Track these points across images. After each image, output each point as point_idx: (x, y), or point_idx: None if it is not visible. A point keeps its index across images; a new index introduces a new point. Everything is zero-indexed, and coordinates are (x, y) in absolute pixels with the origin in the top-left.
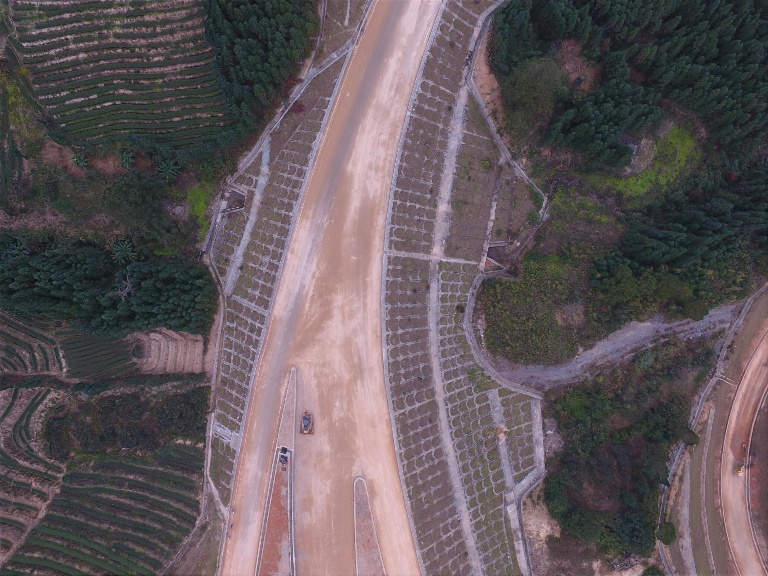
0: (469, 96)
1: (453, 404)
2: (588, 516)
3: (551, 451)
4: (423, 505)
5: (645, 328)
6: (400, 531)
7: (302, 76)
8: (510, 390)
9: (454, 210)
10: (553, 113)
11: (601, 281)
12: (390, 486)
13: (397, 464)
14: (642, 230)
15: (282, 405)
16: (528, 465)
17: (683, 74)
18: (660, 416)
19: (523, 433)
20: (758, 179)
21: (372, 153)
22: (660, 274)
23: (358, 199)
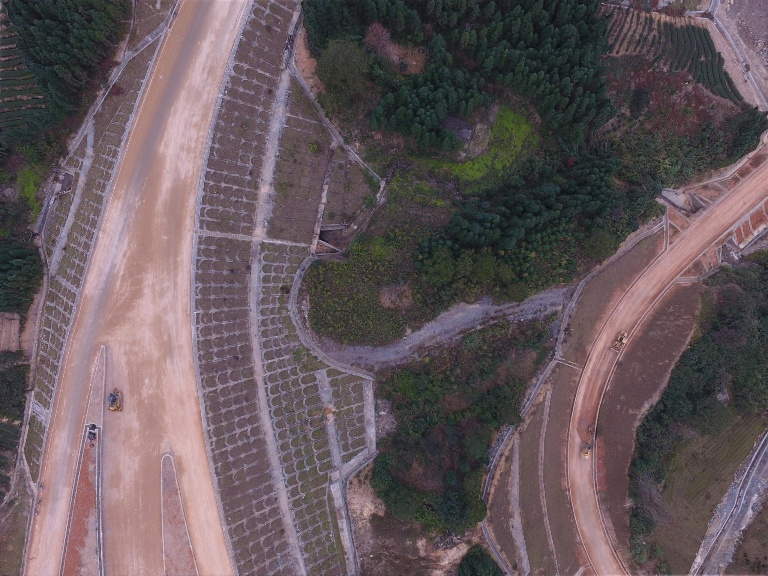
0: (292, 80)
1: (274, 383)
2: (404, 494)
3: (384, 432)
4: (233, 482)
5: (474, 310)
6: (207, 507)
7: (118, 59)
8: (339, 371)
9: (278, 192)
10: (381, 97)
11: (422, 263)
12: (198, 463)
13: (205, 441)
14: (464, 212)
15: (92, 382)
16: (358, 445)
17: (503, 59)
18: (493, 397)
19: (353, 413)
20: (586, 163)
21: (184, 134)
22: (477, 255)
23: (170, 180)
